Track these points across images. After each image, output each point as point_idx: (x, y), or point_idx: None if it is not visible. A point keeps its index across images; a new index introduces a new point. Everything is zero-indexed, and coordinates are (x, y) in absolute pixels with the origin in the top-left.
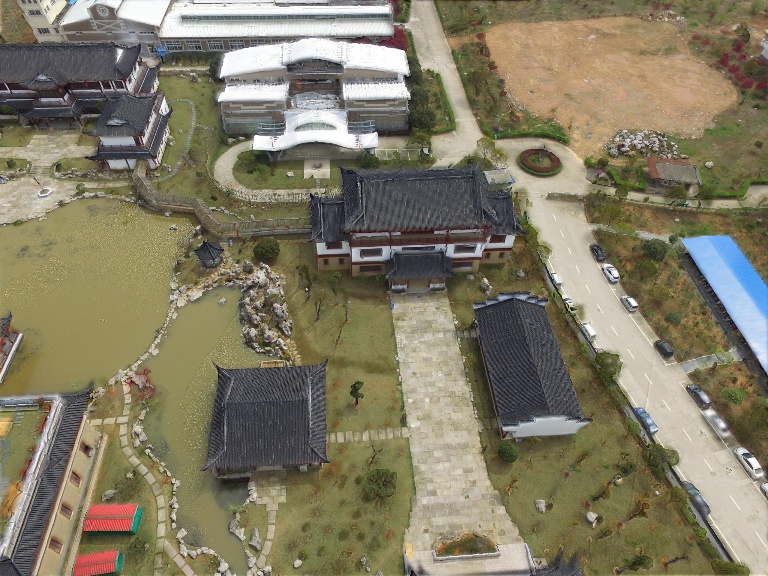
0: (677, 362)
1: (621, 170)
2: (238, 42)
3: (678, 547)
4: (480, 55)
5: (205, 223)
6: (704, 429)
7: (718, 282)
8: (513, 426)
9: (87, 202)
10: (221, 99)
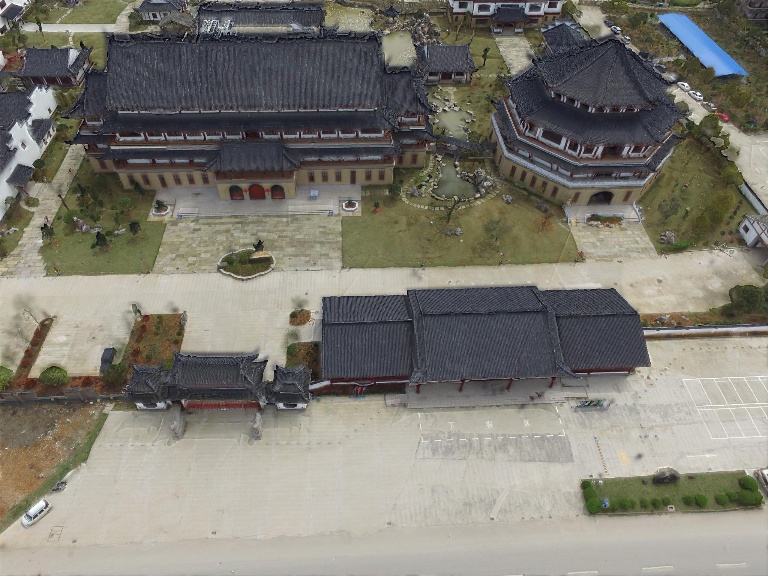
0: None
1: None
2: None
3: None
4: None
5: (383, 5)
6: None
7: (676, 30)
8: None
9: (307, 2)
10: None
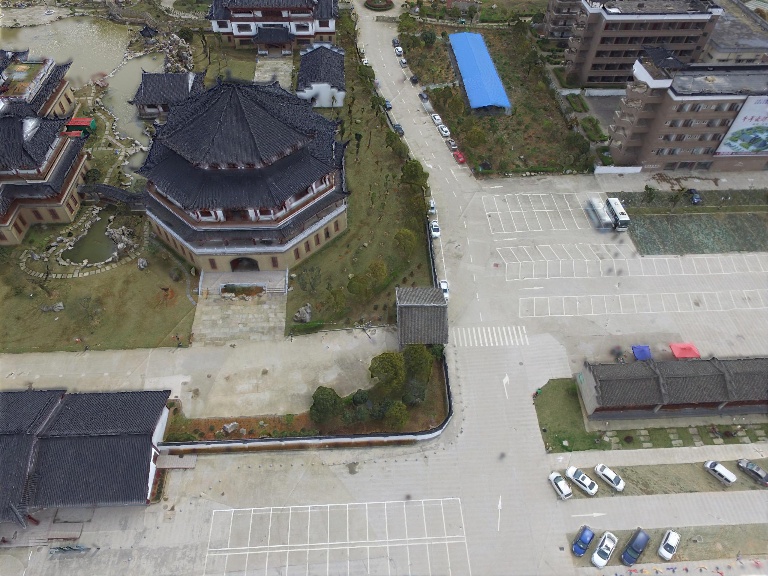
0: (420, 86)
1: (433, 9)
2: None
3: (379, 143)
4: None
5: (149, 23)
6: (420, 109)
7: (459, 51)
8: (302, 92)
9: (77, 18)
10: None
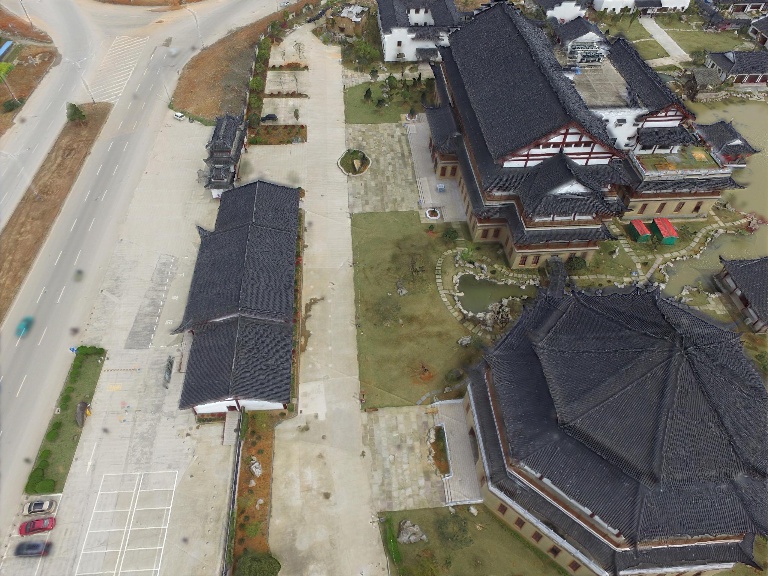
0: None
1: None
2: None
3: None
4: None
5: None
6: None
7: None
8: None
9: None
10: None
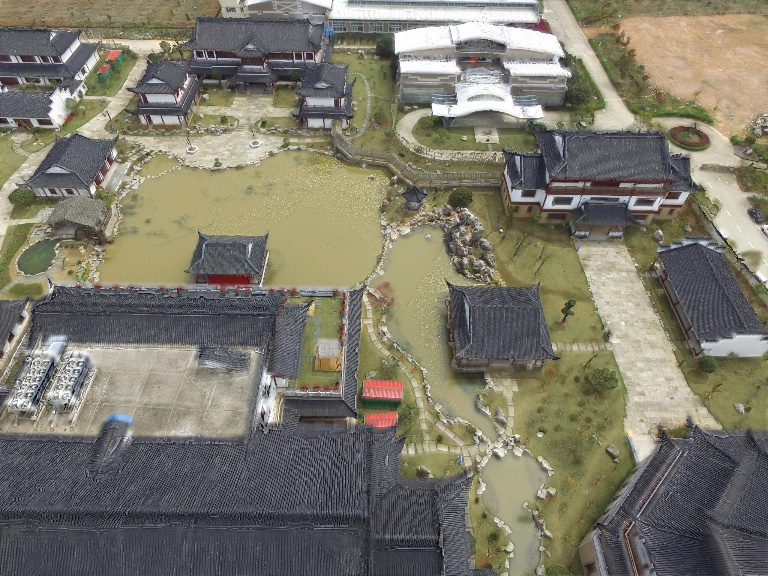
0: None
1: (766, 148)
2: (397, 25)
3: None
4: (616, 44)
5: (403, 173)
6: None
7: None
8: (713, 342)
9: (292, 153)
10: (403, 71)
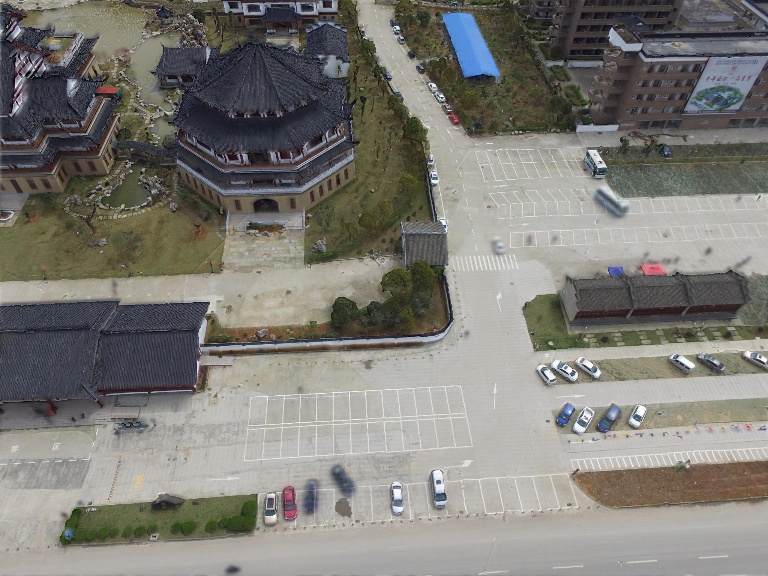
0: (417, 60)
1: None
2: None
3: (382, 108)
4: None
5: (164, 6)
6: (417, 79)
7: (452, 29)
8: None
9: (94, 2)
10: None
